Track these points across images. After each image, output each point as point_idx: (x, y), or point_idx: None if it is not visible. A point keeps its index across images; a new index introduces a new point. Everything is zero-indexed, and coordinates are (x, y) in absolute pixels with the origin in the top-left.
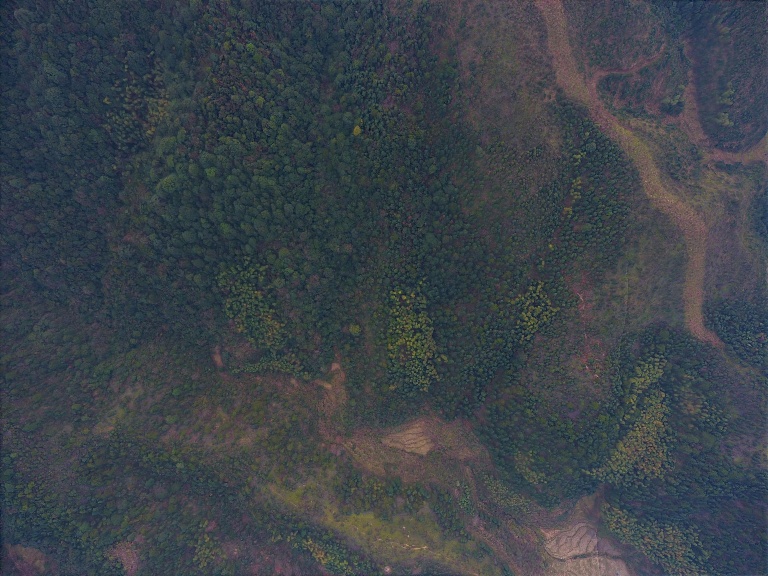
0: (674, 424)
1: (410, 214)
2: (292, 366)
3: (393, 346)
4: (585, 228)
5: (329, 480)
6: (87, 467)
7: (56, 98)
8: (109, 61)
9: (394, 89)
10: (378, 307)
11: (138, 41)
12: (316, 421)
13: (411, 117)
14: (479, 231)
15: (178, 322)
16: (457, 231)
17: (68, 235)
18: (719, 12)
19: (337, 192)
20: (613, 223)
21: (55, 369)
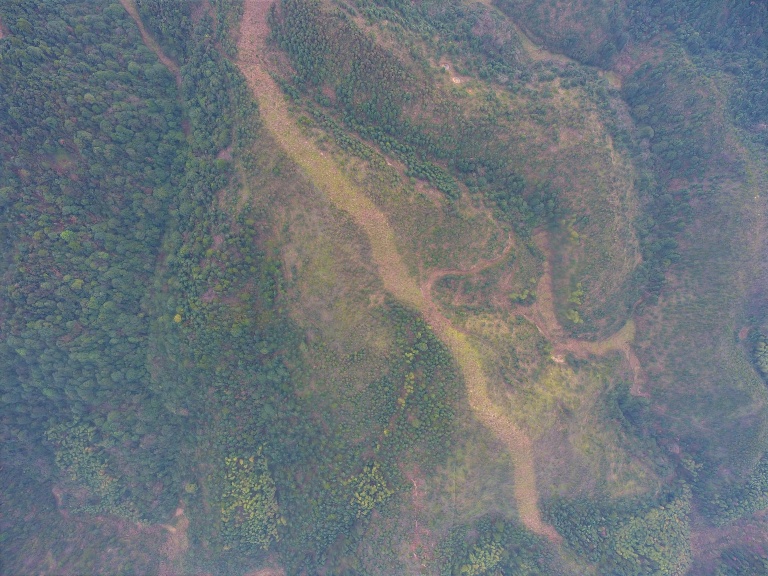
0: None
1: (244, 389)
2: (131, 513)
3: (226, 510)
4: (414, 425)
5: None
6: None
7: None
8: None
9: (215, 284)
10: (213, 470)
11: None
12: (156, 565)
13: (235, 308)
14: (309, 416)
15: (16, 461)
16: (289, 411)
17: None
18: (570, 215)
19: (167, 364)
20: (440, 425)
21: None
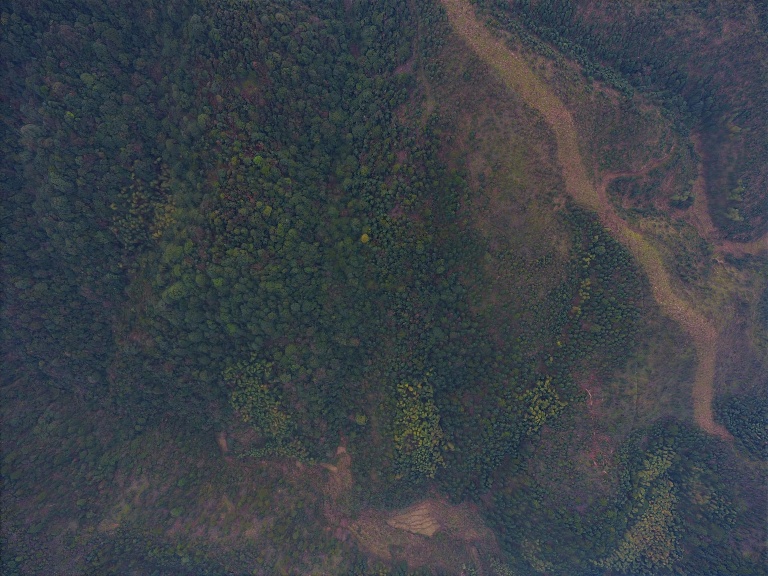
0: (682, 512)
1: (417, 311)
2: (298, 453)
3: (400, 438)
4: (594, 330)
5: (335, 568)
6: (92, 565)
7: (62, 207)
8: (116, 171)
9: (402, 199)
10: (385, 399)
11: (145, 149)
12: (321, 504)
13: (419, 224)
14: (487, 331)
15: (183, 409)
16: (465, 329)
17: (73, 329)
18: (729, 111)
19: (344, 291)
20: (622, 326)
21: (60, 463)
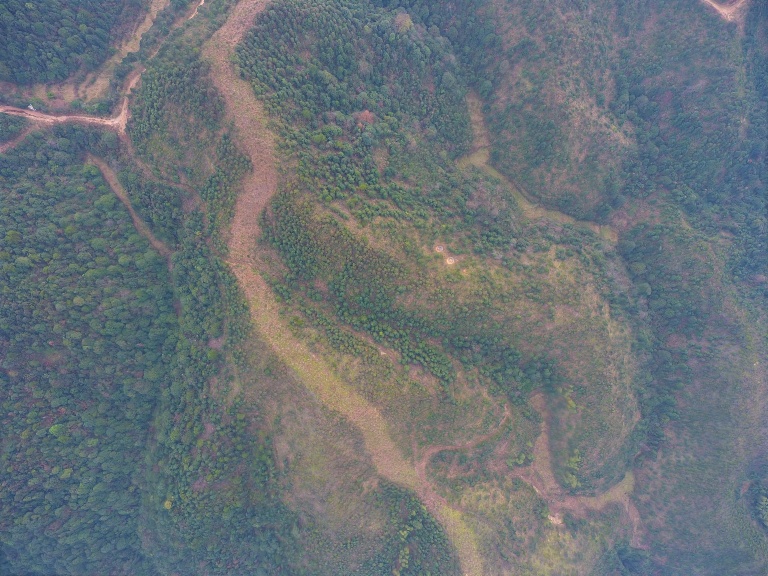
0: None
1: (236, 558)
2: None
3: None
4: None
5: None
6: None
7: None
8: None
9: (206, 473)
10: None
11: None
12: None
13: (226, 493)
14: None
15: None
16: None
17: None
18: (567, 383)
19: (158, 537)
20: None
21: None
